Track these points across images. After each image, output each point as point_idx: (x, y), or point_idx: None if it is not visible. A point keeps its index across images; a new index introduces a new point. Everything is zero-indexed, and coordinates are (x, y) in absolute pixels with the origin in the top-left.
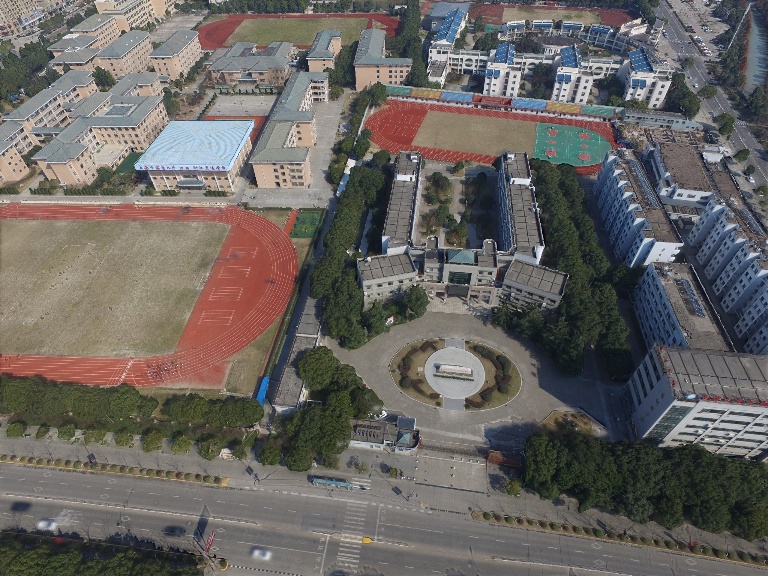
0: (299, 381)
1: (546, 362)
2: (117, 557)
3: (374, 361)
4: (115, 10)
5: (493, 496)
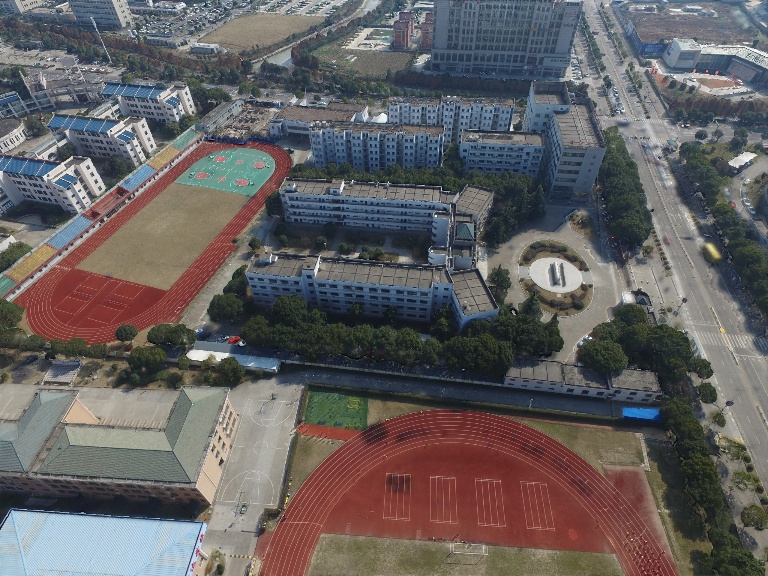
0: (626, 372)
1: (530, 225)
2: None
3: (560, 328)
4: None
5: (652, 264)
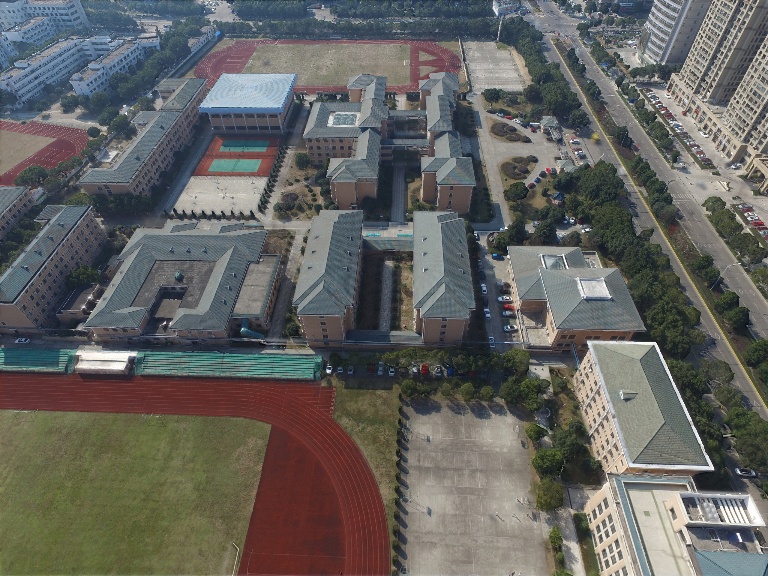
0: None
1: None
2: (256, 7)
3: None
4: (643, 480)
5: None
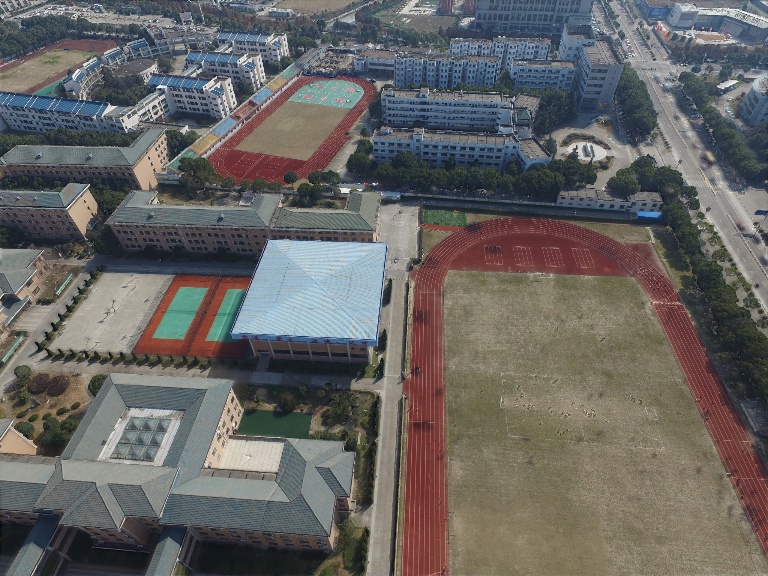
0: (639, 193)
1: (566, 125)
2: None
3: None
4: None
5: (657, 146)
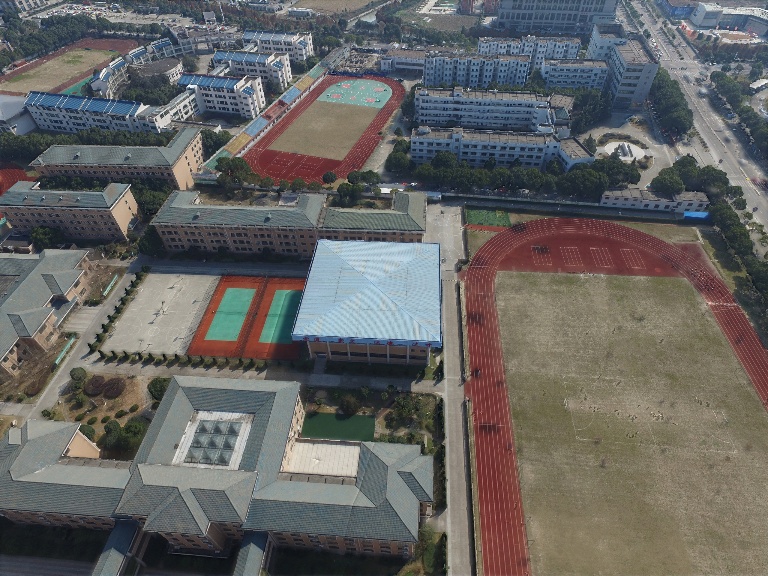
0: (684, 193)
1: (600, 124)
2: None
3: None
4: None
5: (694, 145)
